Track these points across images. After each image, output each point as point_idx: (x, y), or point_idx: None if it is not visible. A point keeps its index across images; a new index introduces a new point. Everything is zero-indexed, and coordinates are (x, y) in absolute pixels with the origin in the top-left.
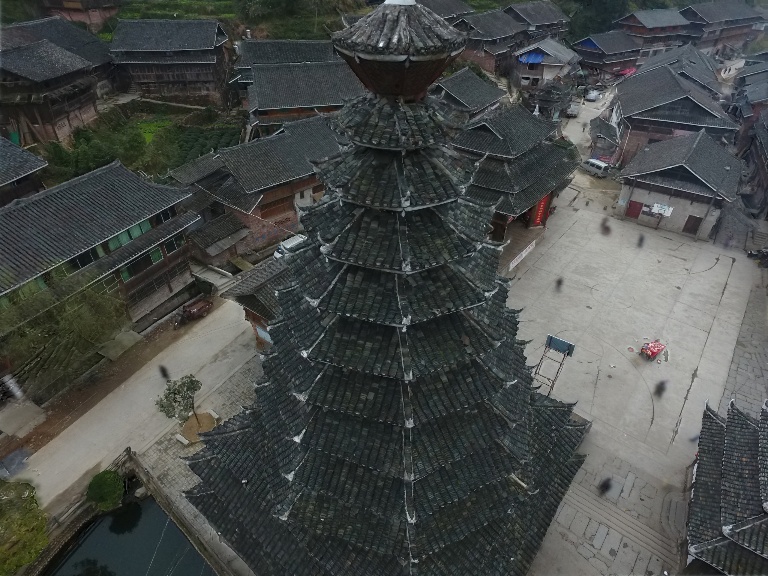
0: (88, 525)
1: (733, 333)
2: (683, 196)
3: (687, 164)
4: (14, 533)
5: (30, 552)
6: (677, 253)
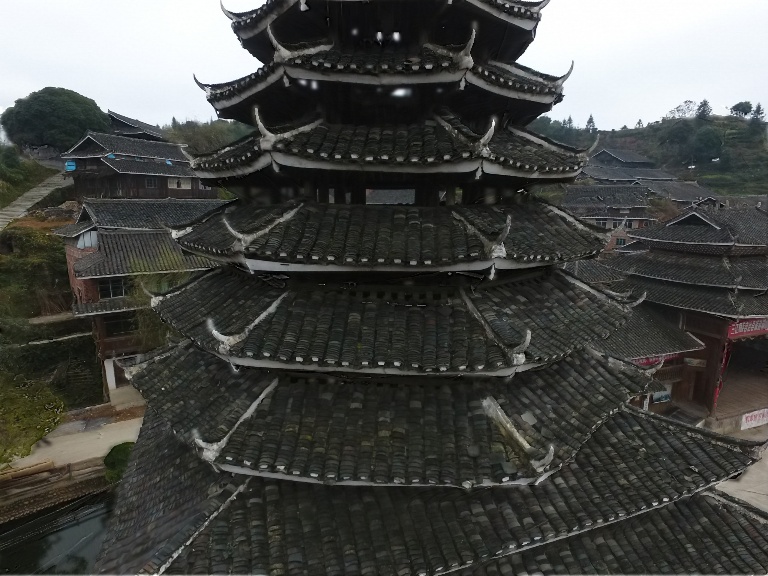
0: (94, 500)
1: None
2: None
3: None
4: (5, 417)
5: (6, 450)
6: None
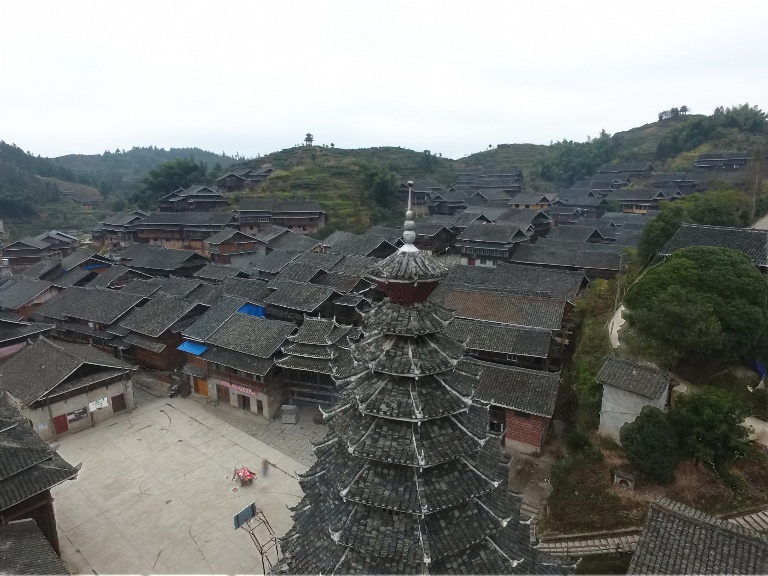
0: None
1: (242, 434)
2: (97, 387)
3: (87, 361)
4: None
5: None
6: (137, 427)
